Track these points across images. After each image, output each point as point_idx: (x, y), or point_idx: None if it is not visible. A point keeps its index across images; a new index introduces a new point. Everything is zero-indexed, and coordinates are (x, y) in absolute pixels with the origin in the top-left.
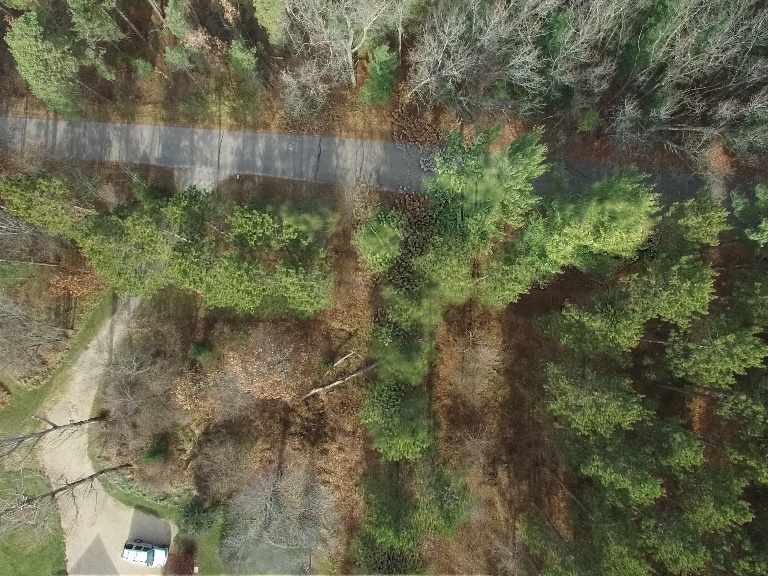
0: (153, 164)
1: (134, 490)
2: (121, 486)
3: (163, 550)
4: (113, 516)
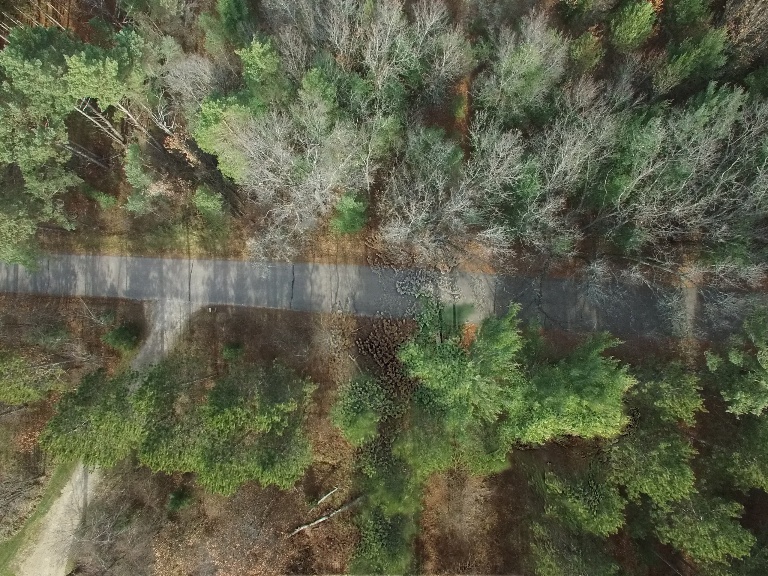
0: (121, 297)
1: None
2: None
3: None
4: None
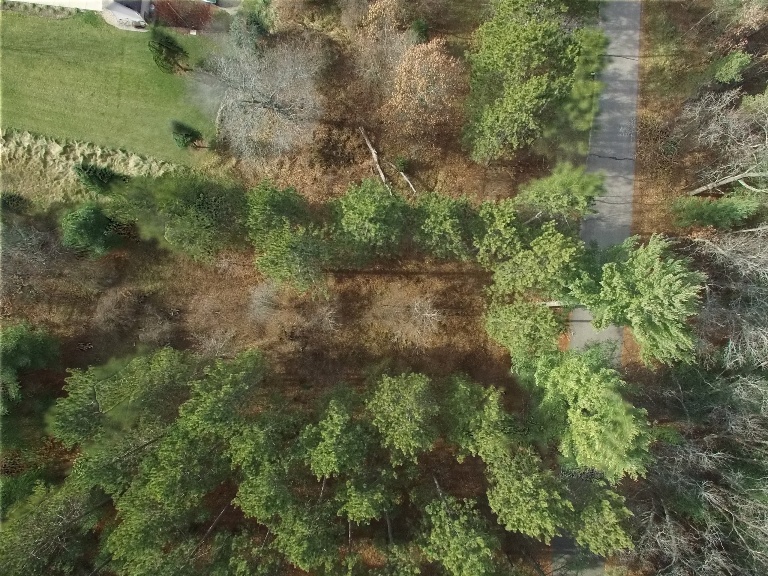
0: None
1: None
2: None
3: None
4: None
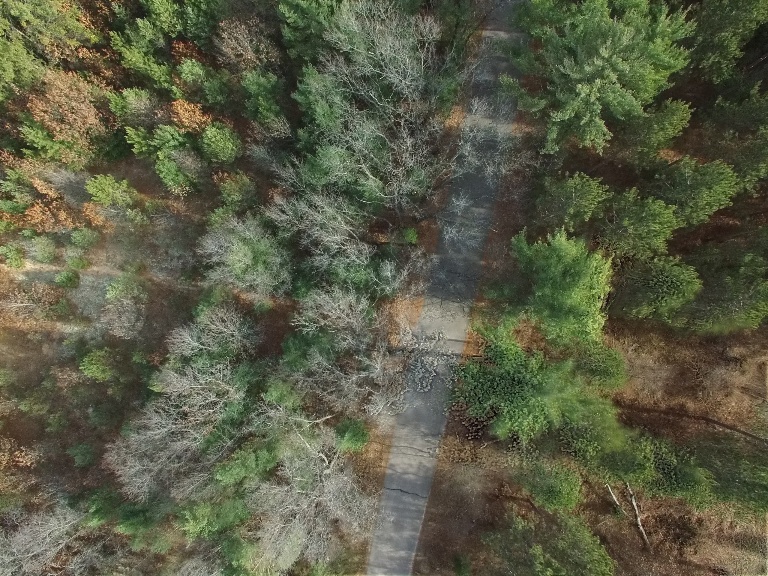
0: None
1: None
2: None
3: None
4: None
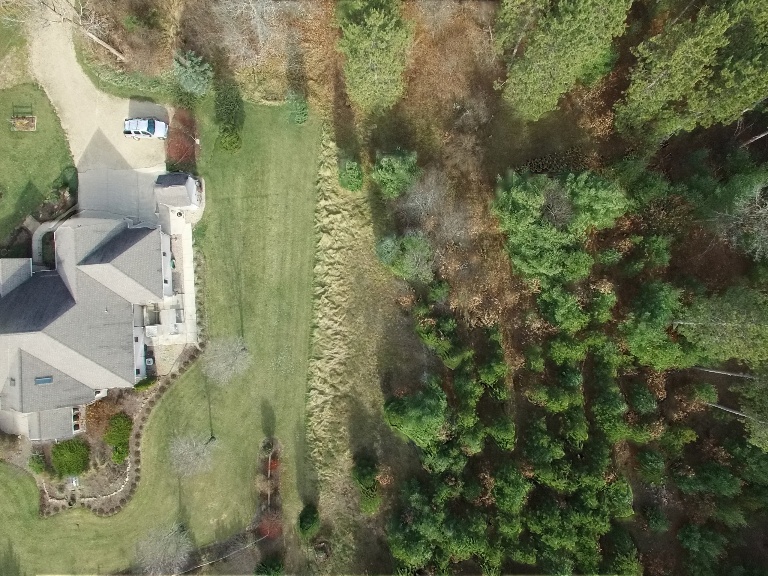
0: None
1: (126, 82)
2: (113, 80)
3: (163, 122)
4: (110, 108)
